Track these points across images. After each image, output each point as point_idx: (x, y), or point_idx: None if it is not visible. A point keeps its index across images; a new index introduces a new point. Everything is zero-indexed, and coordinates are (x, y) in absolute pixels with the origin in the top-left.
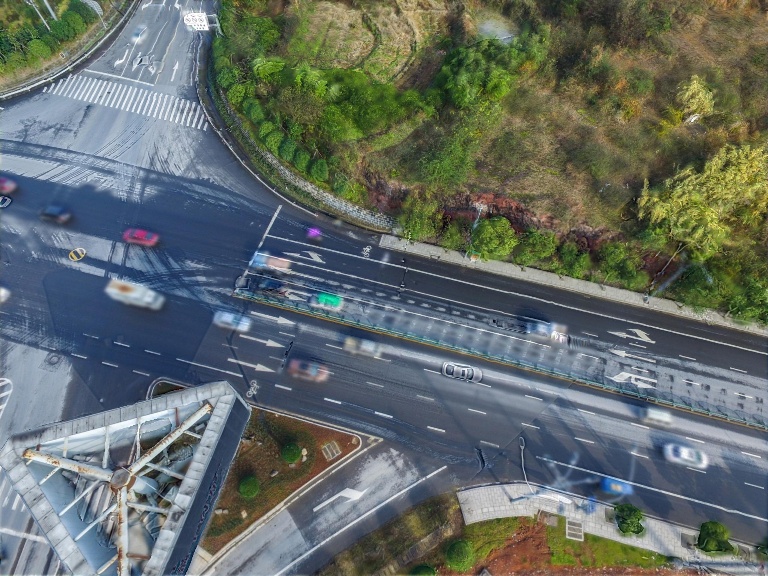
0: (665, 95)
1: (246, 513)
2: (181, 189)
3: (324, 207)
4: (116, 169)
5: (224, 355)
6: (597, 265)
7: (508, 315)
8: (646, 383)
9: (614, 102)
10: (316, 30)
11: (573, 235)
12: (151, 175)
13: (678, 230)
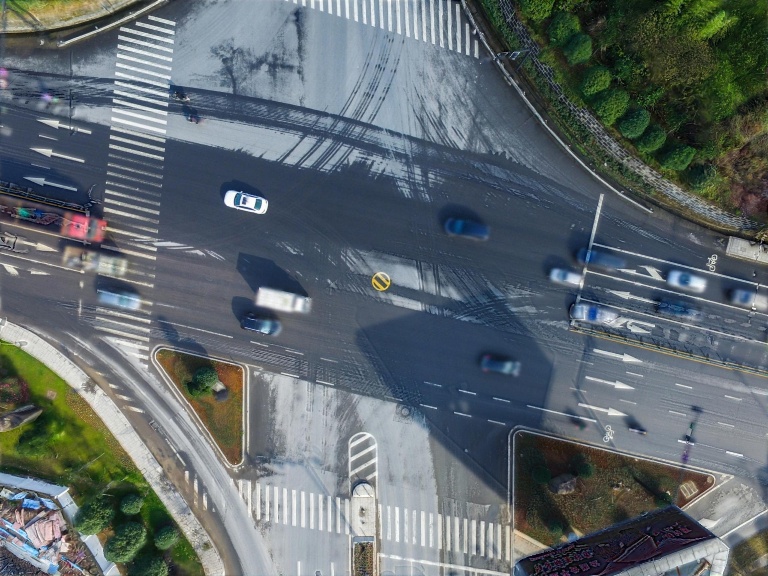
0: None
1: (624, 545)
2: (474, 174)
3: (656, 195)
4: (380, 141)
5: (574, 400)
6: None
7: None
8: None
9: None
10: None
11: None
12: (428, 150)
13: None
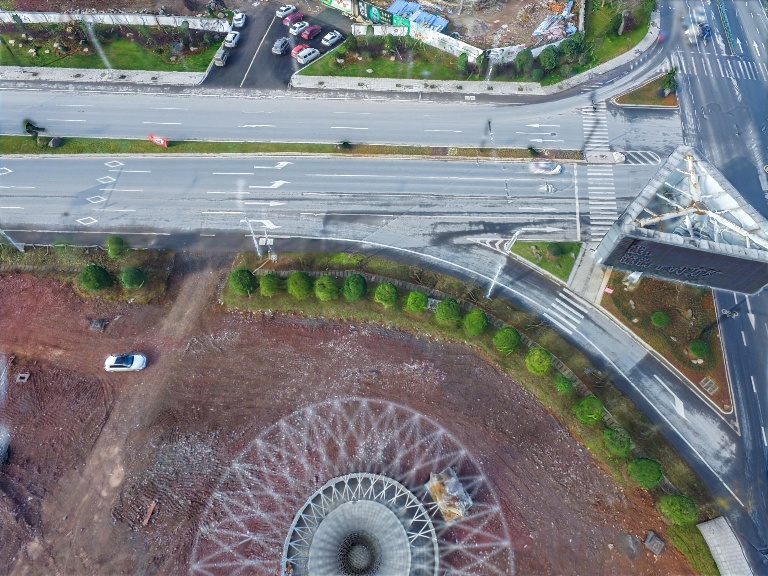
0: None
1: (637, 322)
2: None
3: None
4: None
5: None
6: None
7: None
8: None
9: None
10: None
11: None
12: None
13: None
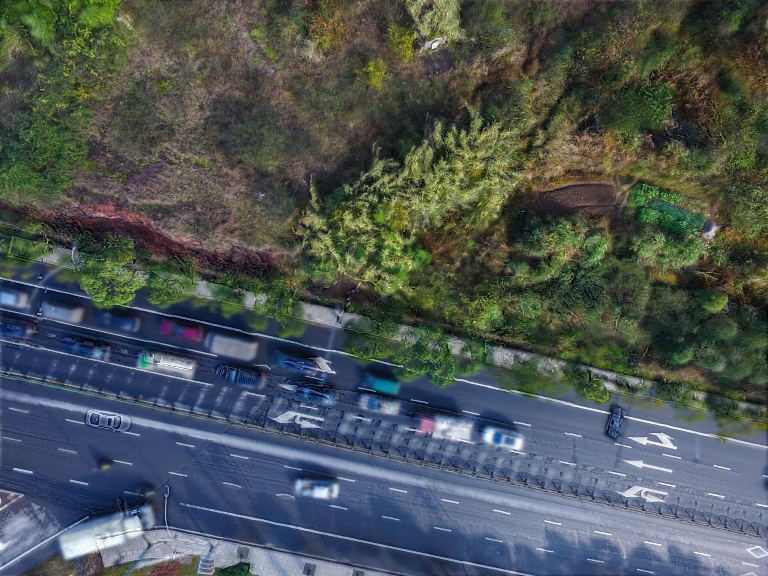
0: None
1: None
2: None
3: None
4: None
5: None
6: None
7: (168, 347)
8: (310, 423)
9: (297, 24)
10: None
11: (239, 250)
12: None
13: (344, 268)
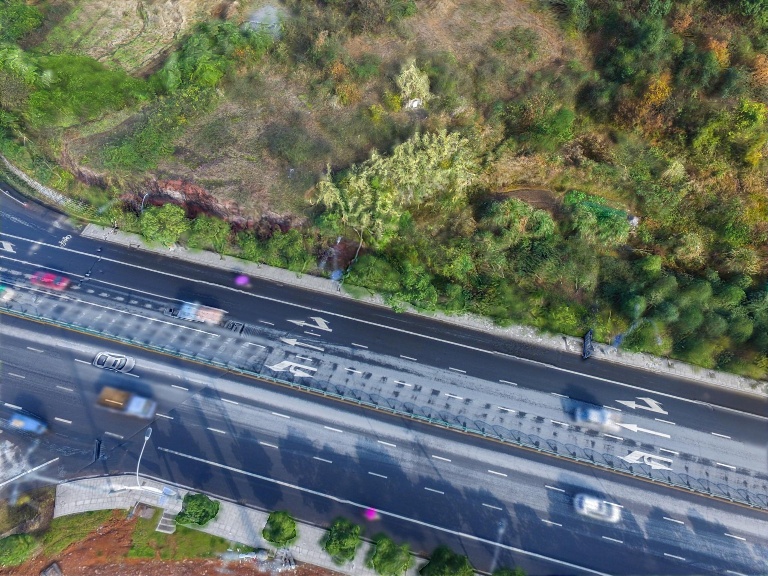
0: (388, 80)
1: None
2: None
3: (39, 196)
4: None
5: None
6: None
7: (188, 304)
8: (304, 372)
9: (328, 87)
10: (86, 18)
11: (266, 222)
12: None
13: (348, 215)
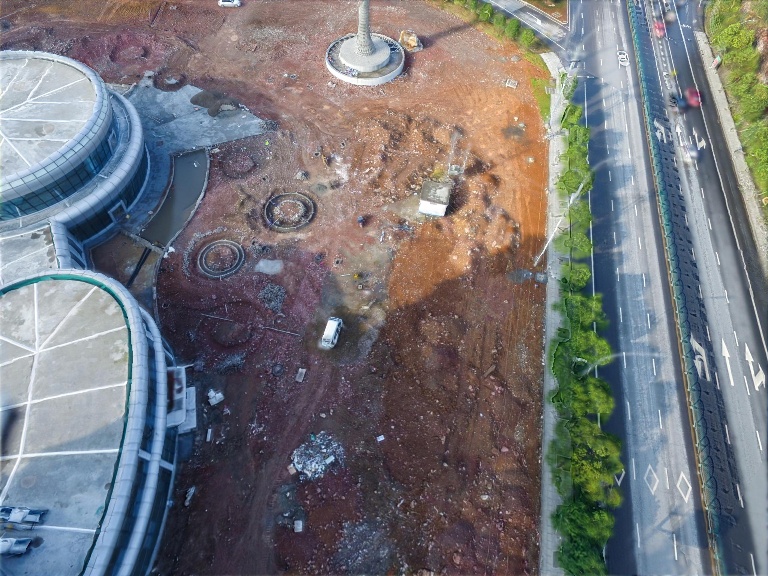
0: None
1: None
2: None
3: (709, 11)
4: None
5: None
6: (752, 119)
7: (676, 80)
8: (661, 136)
9: None
10: None
11: None
12: None
13: None
